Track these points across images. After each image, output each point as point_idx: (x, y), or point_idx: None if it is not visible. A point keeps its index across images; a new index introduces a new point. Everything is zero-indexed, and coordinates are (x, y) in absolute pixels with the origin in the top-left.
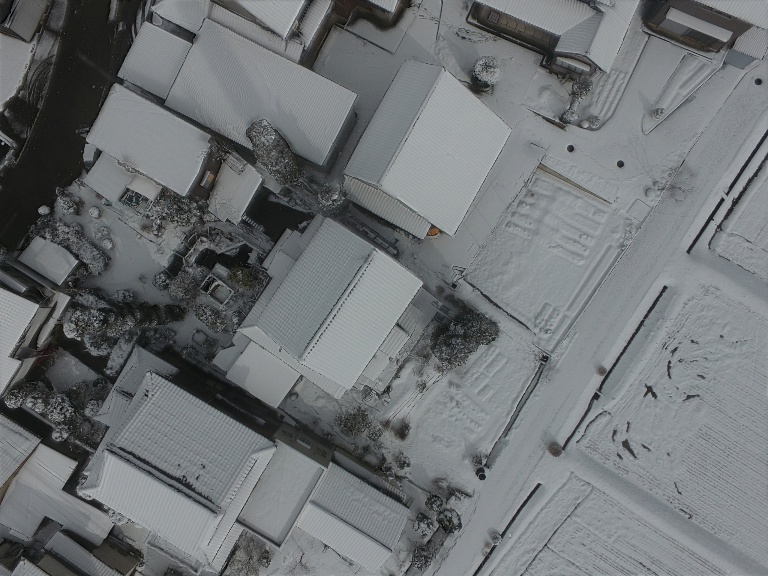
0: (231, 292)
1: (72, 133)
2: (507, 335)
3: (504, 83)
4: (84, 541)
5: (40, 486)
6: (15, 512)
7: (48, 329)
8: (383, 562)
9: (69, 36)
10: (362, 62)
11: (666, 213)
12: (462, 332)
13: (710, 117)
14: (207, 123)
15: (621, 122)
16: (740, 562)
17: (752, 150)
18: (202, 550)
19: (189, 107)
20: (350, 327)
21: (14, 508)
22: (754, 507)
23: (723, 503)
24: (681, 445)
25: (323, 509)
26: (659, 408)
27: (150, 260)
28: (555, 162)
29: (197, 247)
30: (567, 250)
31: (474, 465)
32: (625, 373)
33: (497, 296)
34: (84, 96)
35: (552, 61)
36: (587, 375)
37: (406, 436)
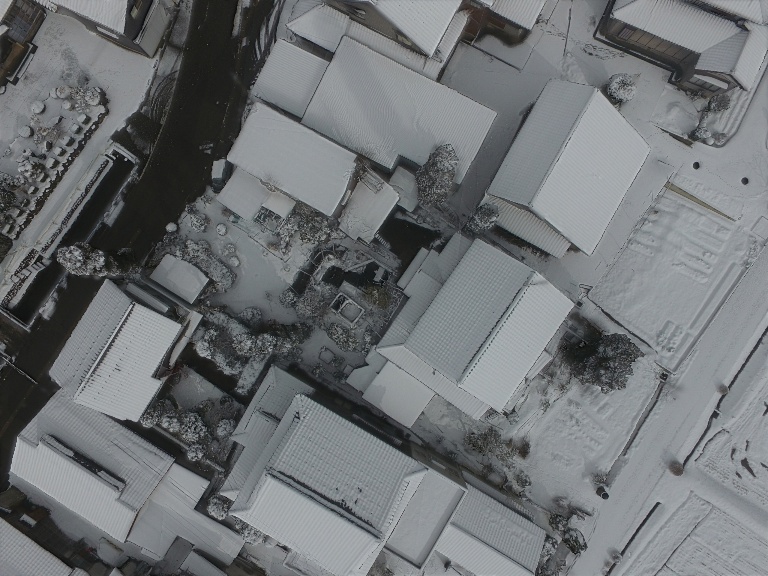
0: (361, 311)
1: (196, 149)
2: None
3: (632, 100)
4: (216, 561)
5: (173, 505)
6: (149, 532)
7: (180, 348)
8: None
9: (192, 52)
10: (489, 78)
11: None
12: (611, 354)
13: None
14: (344, 141)
15: (745, 139)
16: None
17: None
18: (354, 574)
19: (326, 125)
20: (506, 350)
21: (147, 528)
22: None
23: None
24: None
25: (464, 531)
26: None
27: (276, 277)
28: (681, 179)
29: (324, 265)
30: (690, 268)
31: (595, 484)
32: (745, 391)
33: (619, 314)
34: (208, 112)
35: (683, 78)
36: (708, 393)
37: (527, 454)
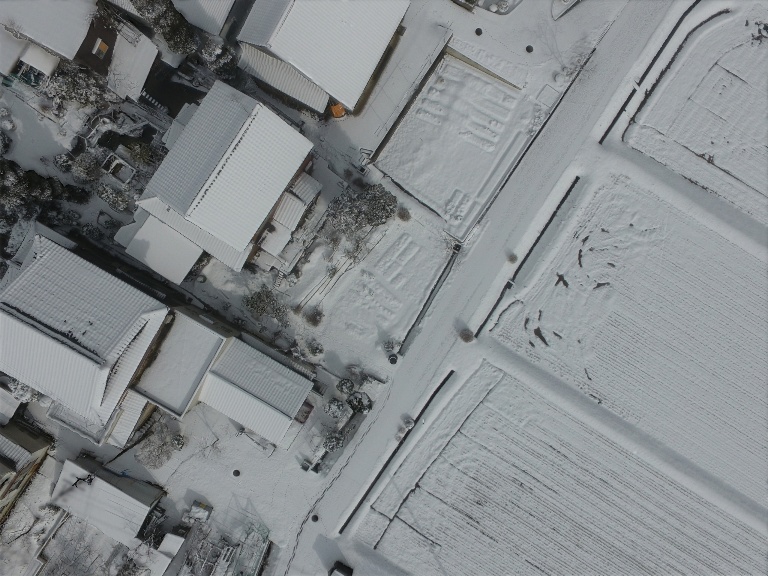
0: (133, 171)
1: None
2: (419, 223)
3: None
4: None
5: None
6: None
7: None
8: (285, 432)
9: None
10: None
11: (577, 102)
12: (355, 196)
13: (622, 6)
14: None
15: (531, 7)
16: (646, 443)
17: (664, 40)
18: (94, 410)
19: None
20: (237, 185)
21: None
22: (661, 391)
23: (631, 388)
24: (591, 332)
25: (223, 379)
26: (570, 296)
27: (53, 142)
28: (463, 45)
29: (100, 128)
30: (477, 136)
31: (387, 351)
32: (537, 262)
33: (408, 183)
34: None
35: None
36: (499, 263)
37: (319, 323)
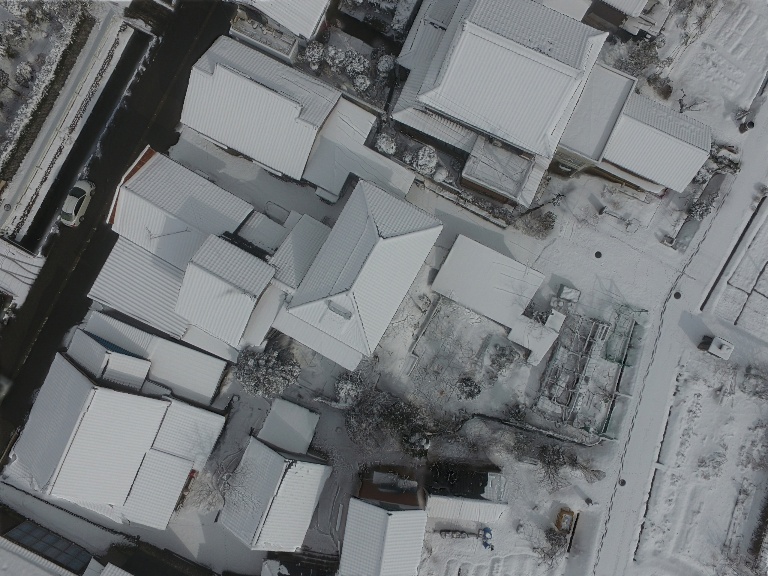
0: None
1: None
2: None
3: None
4: None
5: (343, 141)
6: (323, 167)
7: None
8: (695, 173)
9: None
10: None
11: None
12: None
13: None
14: None
15: None
16: None
17: None
18: (547, 138)
19: None
20: None
21: (321, 163)
22: None
23: None
24: None
25: (637, 120)
26: None
27: None
28: None
29: None
30: None
31: (737, 120)
32: None
33: None
34: None
35: None
36: None
37: (669, 97)
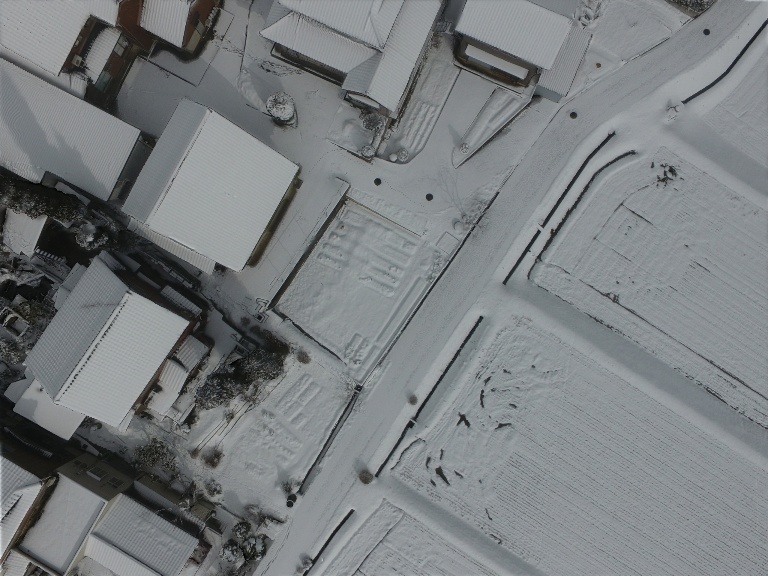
0: (27, 324)
1: None
2: (319, 365)
3: (308, 117)
4: None
5: None
6: None
7: None
8: None
9: None
10: (165, 94)
11: (480, 245)
12: (232, 370)
13: (525, 150)
14: None
15: (431, 155)
16: None
17: (569, 183)
18: None
19: None
20: (109, 367)
21: None
22: (561, 533)
23: (532, 529)
24: (492, 472)
25: (104, 541)
26: (471, 436)
27: None
28: (361, 195)
29: None
30: (377, 282)
31: (285, 492)
32: (438, 402)
33: (308, 326)
34: None
35: None
36: (399, 404)
37: (218, 464)
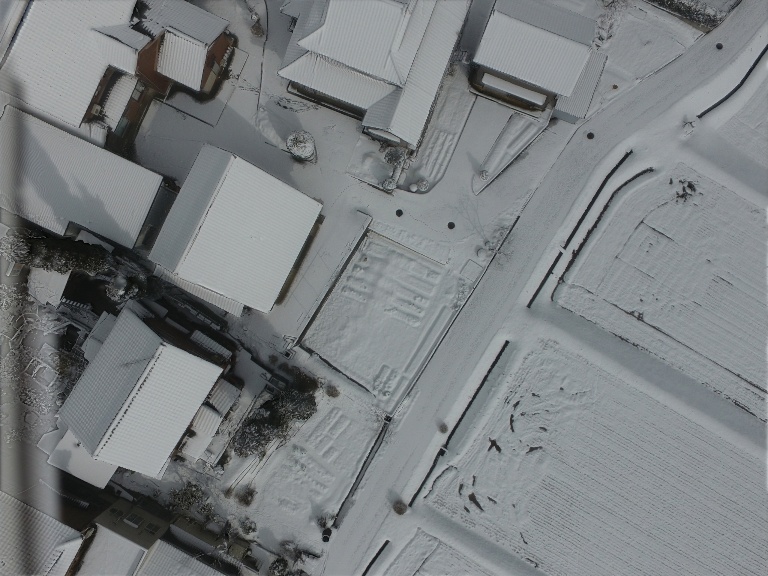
0: (56, 374)
1: None
2: (348, 398)
3: (327, 152)
4: None
5: None
6: None
7: None
8: None
9: None
10: (183, 136)
11: (503, 270)
12: (268, 414)
13: (544, 173)
14: (15, 210)
15: (451, 183)
16: None
17: (588, 203)
18: None
19: None
20: (146, 419)
21: None
22: (597, 553)
23: (567, 551)
24: (525, 496)
25: None
26: (503, 461)
27: None
28: (384, 227)
29: (24, 328)
30: (403, 312)
31: (320, 527)
32: (468, 429)
33: (336, 360)
34: None
35: None
36: (430, 433)
37: (251, 502)
